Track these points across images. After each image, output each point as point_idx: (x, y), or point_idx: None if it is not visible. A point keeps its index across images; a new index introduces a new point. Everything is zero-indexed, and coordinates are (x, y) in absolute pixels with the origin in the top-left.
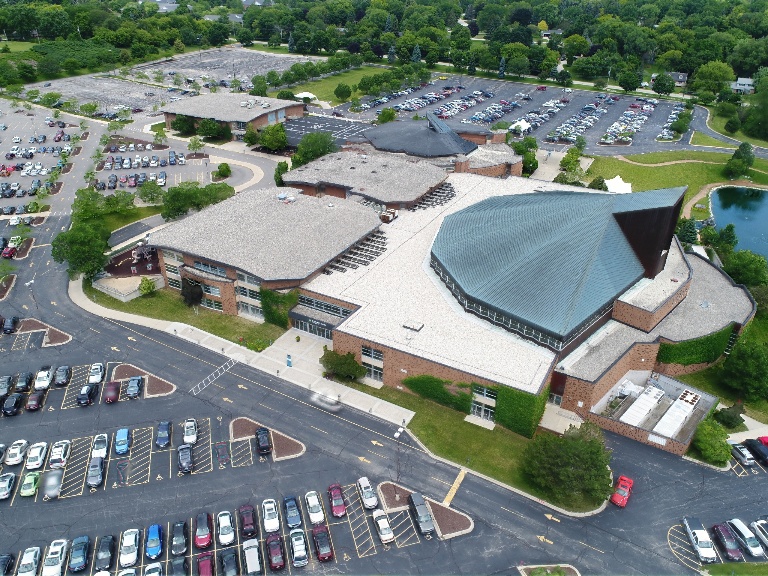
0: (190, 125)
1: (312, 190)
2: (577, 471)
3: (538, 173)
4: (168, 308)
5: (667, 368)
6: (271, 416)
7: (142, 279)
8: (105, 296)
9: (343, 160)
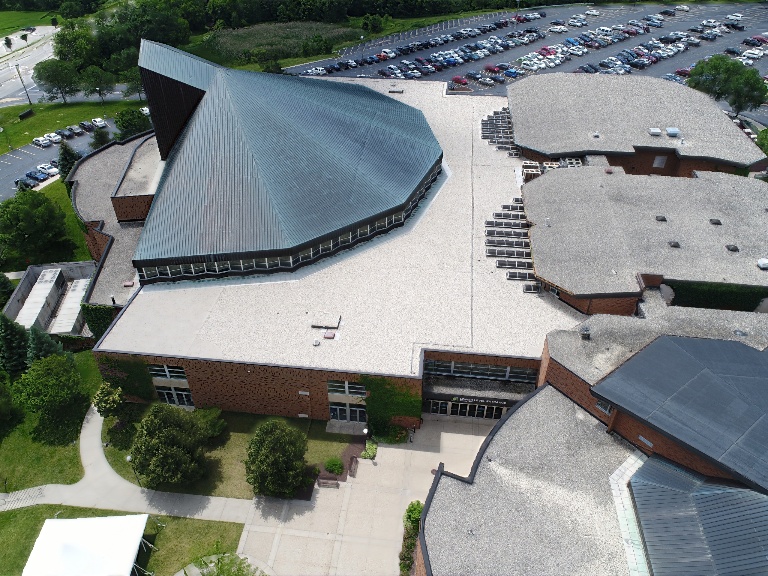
0: None
1: None
2: None
3: None
4: None
5: None
6: None
7: None
8: None
9: None
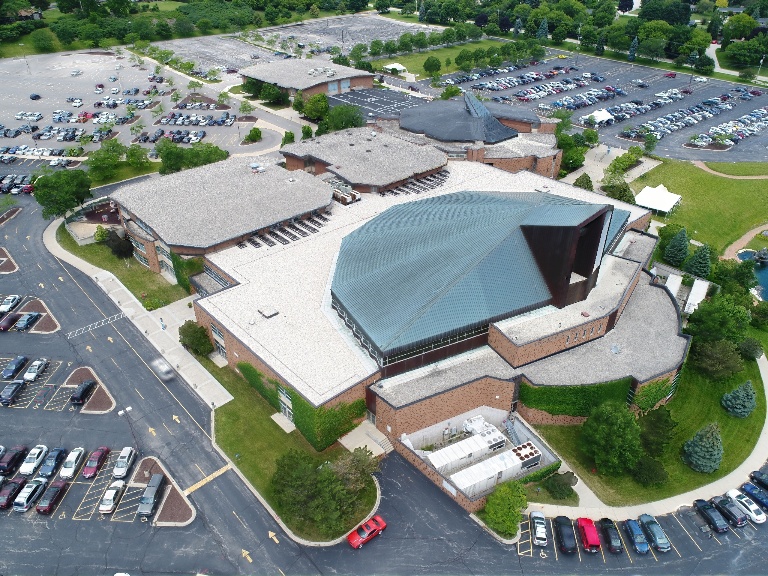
0: (259, 89)
1: (301, 163)
2: (298, 495)
3: (582, 171)
4: (110, 257)
5: (528, 413)
6: (111, 371)
7: (97, 227)
8: (69, 238)
9: (352, 136)
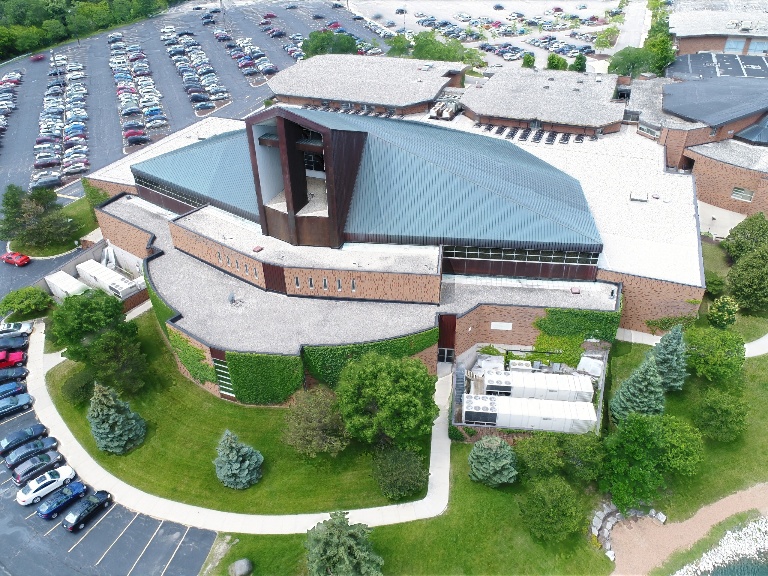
0: None
1: None
2: None
3: None
4: None
5: None
6: None
7: None
8: None
9: (580, 75)
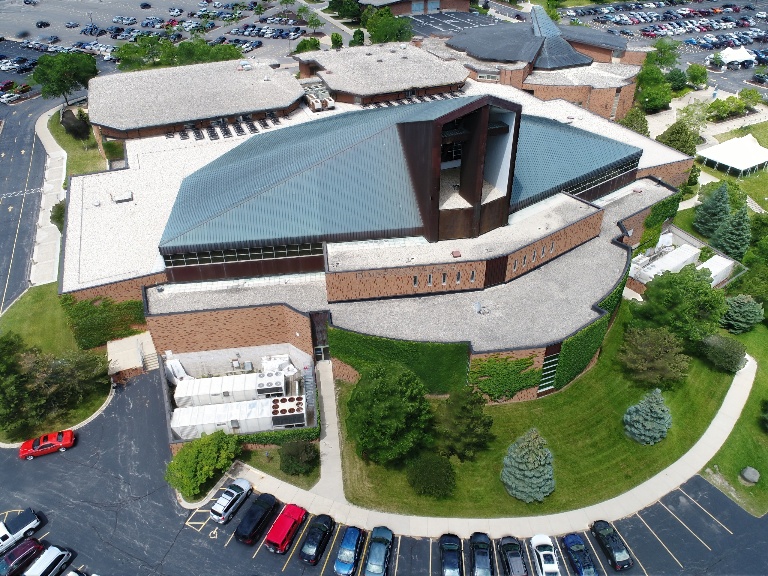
0: None
1: (307, 69)
2: None
3: (663, 115)
4: None
5: (332, 363)
6: None
7: (78, 109)
8: None
9: (380, 47)
